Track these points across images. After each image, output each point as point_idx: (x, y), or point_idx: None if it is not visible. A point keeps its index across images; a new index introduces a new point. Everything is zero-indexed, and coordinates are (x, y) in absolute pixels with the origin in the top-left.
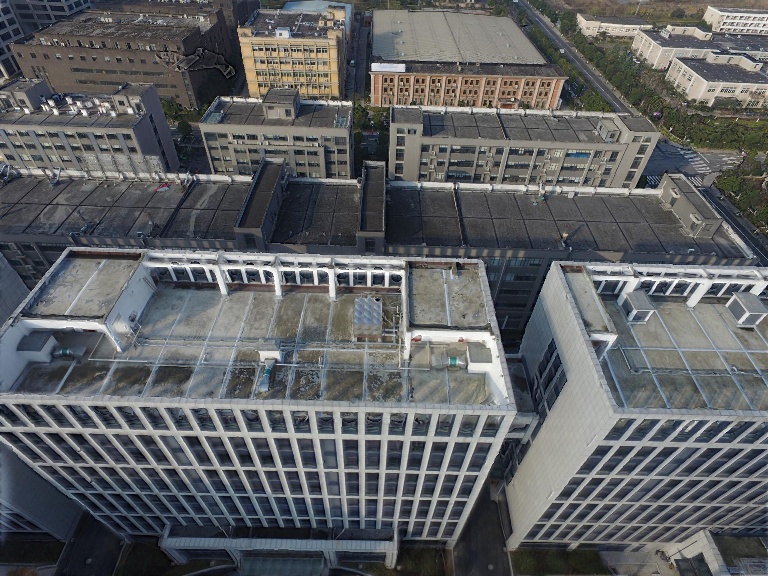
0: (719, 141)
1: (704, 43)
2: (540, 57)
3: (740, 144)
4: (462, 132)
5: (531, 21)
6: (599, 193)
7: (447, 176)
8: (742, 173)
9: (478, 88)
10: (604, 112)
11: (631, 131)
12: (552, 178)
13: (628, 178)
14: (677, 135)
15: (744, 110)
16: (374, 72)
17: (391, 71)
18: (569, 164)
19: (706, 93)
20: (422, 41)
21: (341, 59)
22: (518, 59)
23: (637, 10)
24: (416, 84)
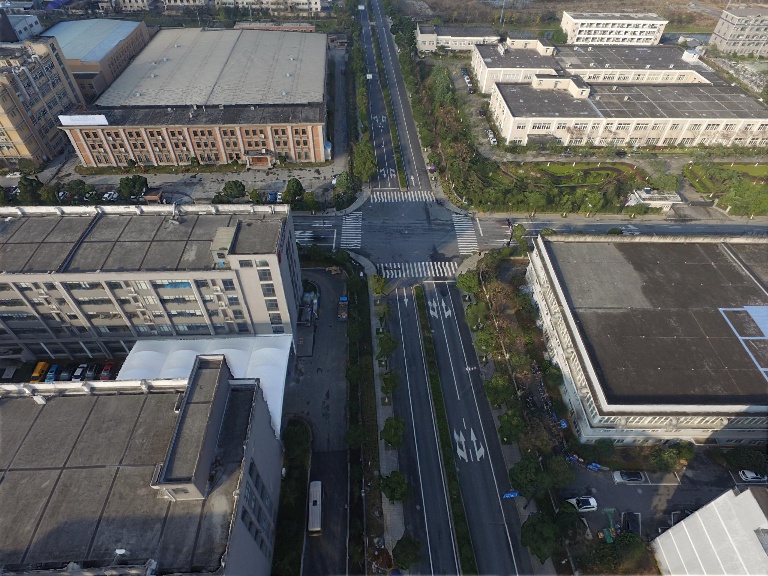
0: (504, 202)
1: (543, 60)
2: (320, 90)
3: (529, 206)
4: (5, 256)
5: (374, 33)
6: (102, 388)
7: (1, 318)
8: (511, 254)
9: (214, 140)
10: (254, 205)
11: (228, 255)
12: (160, 312)
13: (271, 307)
14: (458, 194)
15: (564, 149)
16: (65, 127)
17: (88, 124)
18: (171, 296)
19: (516, 131)
20: (181, 73)
21: (22, 111)
22: (287, 95)
23: (502, 15)
24: (130, 138)
